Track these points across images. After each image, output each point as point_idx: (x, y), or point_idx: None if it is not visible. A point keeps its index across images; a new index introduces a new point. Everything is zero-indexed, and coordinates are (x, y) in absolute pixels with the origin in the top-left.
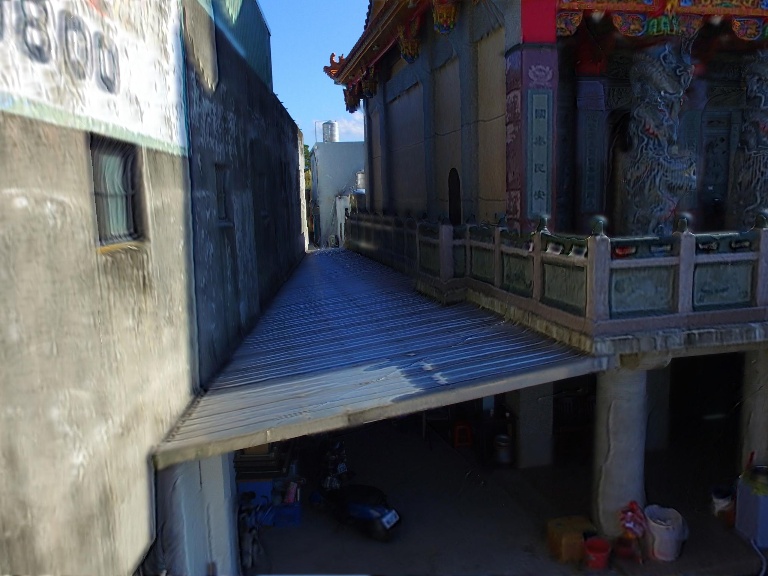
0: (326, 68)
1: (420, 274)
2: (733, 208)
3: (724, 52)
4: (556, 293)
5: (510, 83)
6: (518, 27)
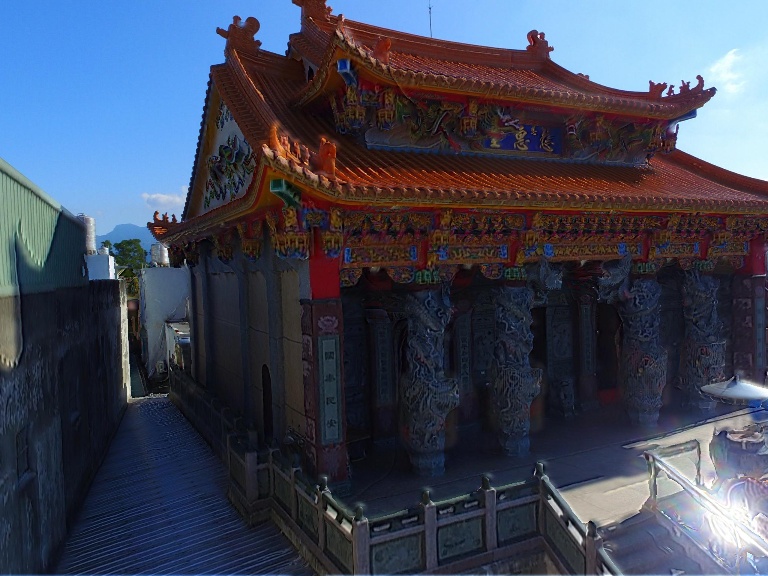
0: (150, 224)
1: (231, 483)
2: (493, 407)
3: (477, 286)
4: (335, 550)
5: (304, 327)
6: (308, 286)
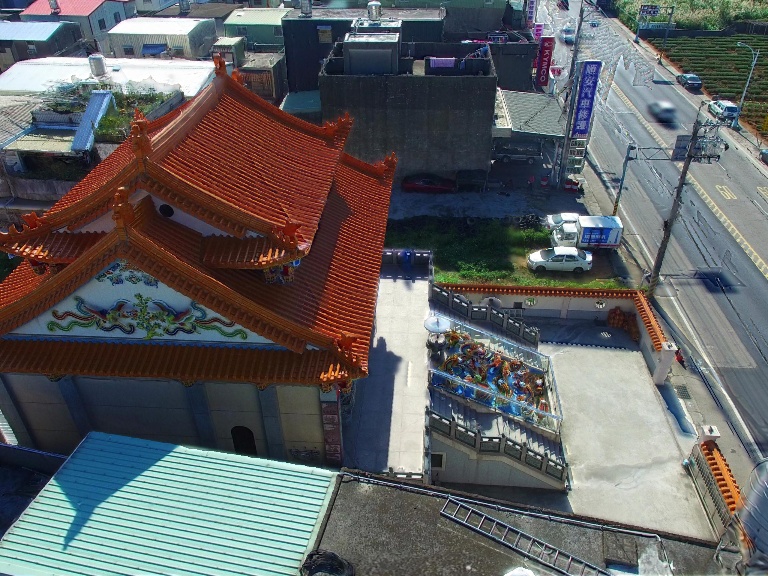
0: None
1: None
2: None
3: None
4: None
5: None
6: (335, 396)
